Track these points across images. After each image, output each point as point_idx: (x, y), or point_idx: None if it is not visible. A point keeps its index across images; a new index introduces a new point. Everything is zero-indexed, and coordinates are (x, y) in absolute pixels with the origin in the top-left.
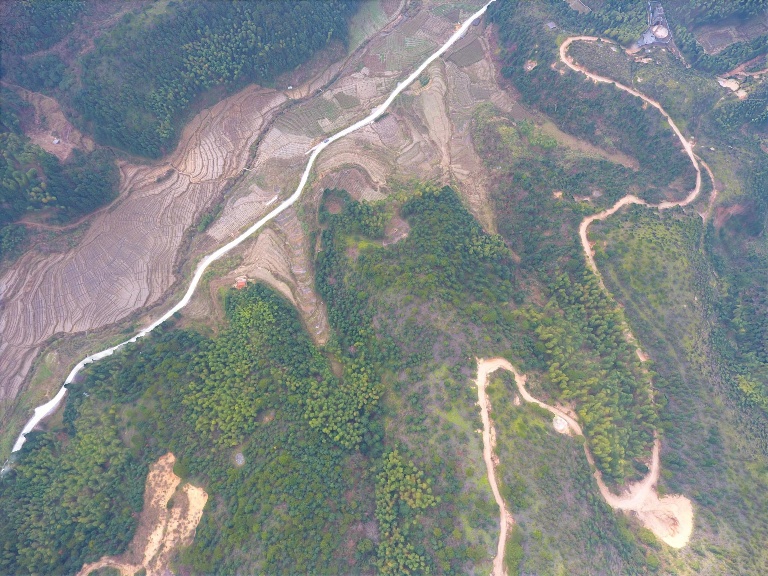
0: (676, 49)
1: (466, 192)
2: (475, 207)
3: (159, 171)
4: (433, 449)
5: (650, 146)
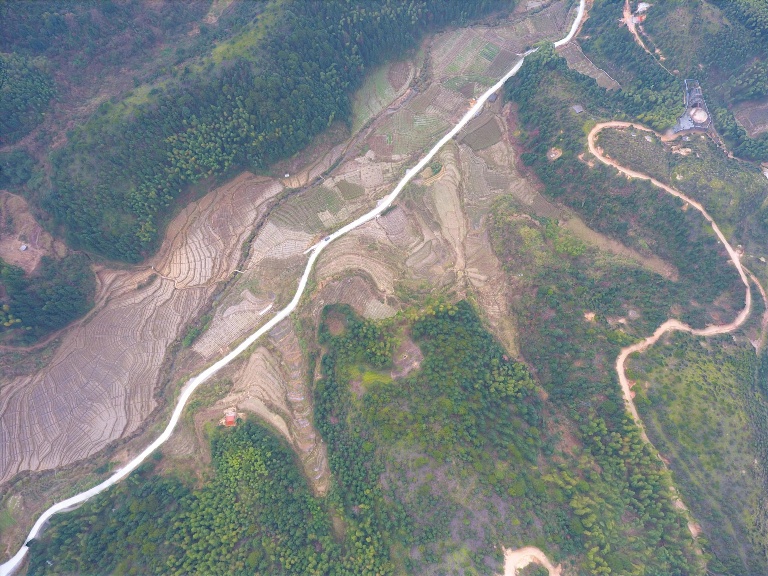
0: (716, 134)
1: (484, 302)
2: (494, 321)
3: (140, 276)
4: None
5: (691, 254)
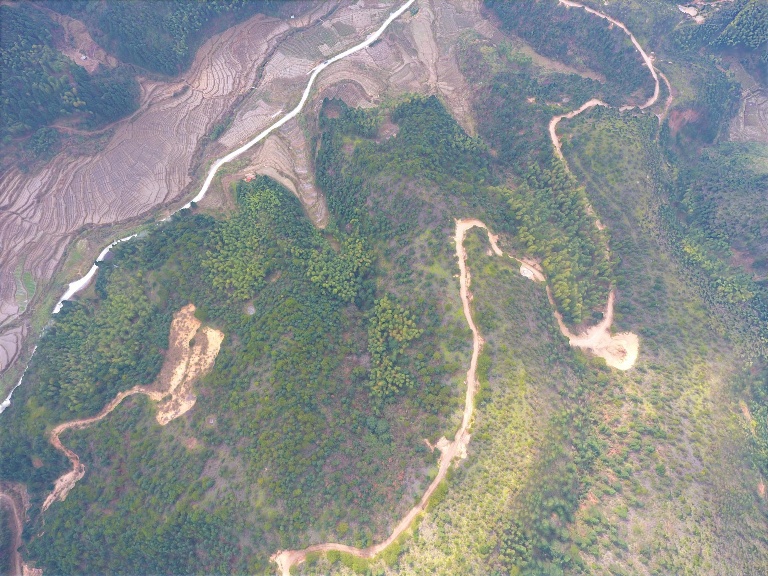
0: None
1: (451, 104)
2: (459, 117)
3: (175, 87)
4: (418, 294)
5: (615, 62)
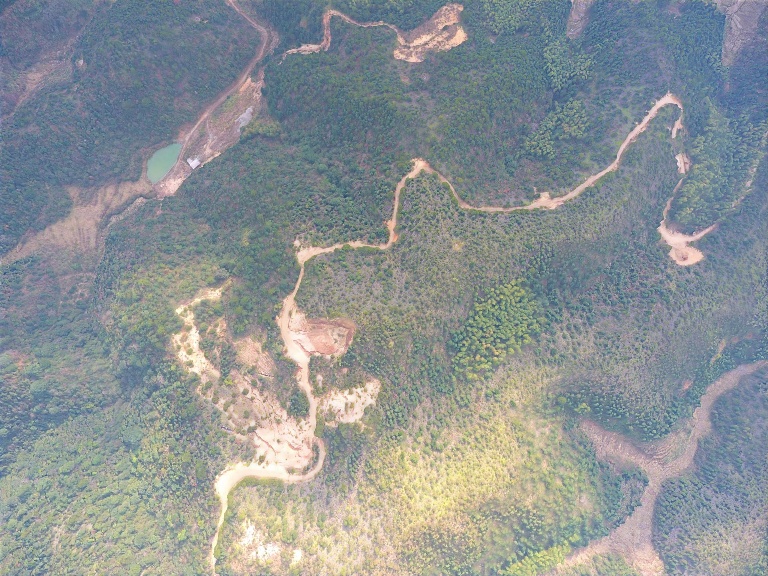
0: None
1: (728, 36)
2: (724, 50)
3: None
4: (601, 115)
5: None
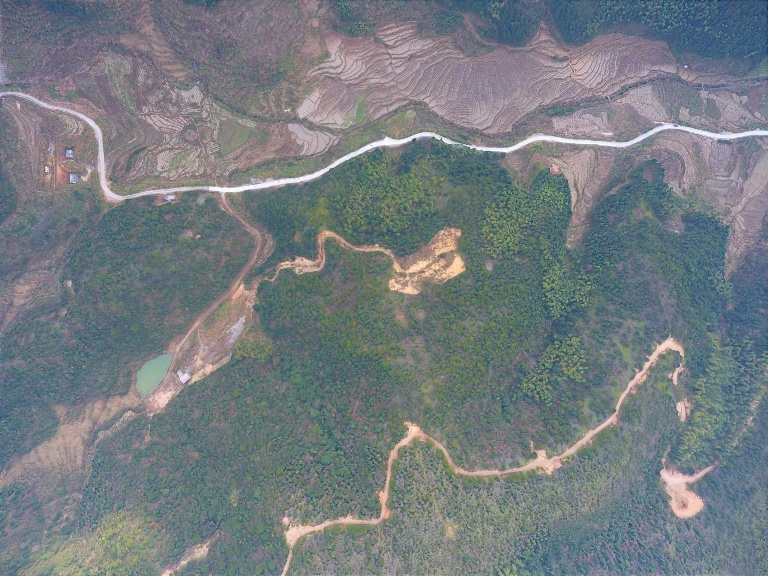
0: None
1: (732, 240)
2: (728, 254)
3: (560, 51)
4: (601, 356)
5: None
